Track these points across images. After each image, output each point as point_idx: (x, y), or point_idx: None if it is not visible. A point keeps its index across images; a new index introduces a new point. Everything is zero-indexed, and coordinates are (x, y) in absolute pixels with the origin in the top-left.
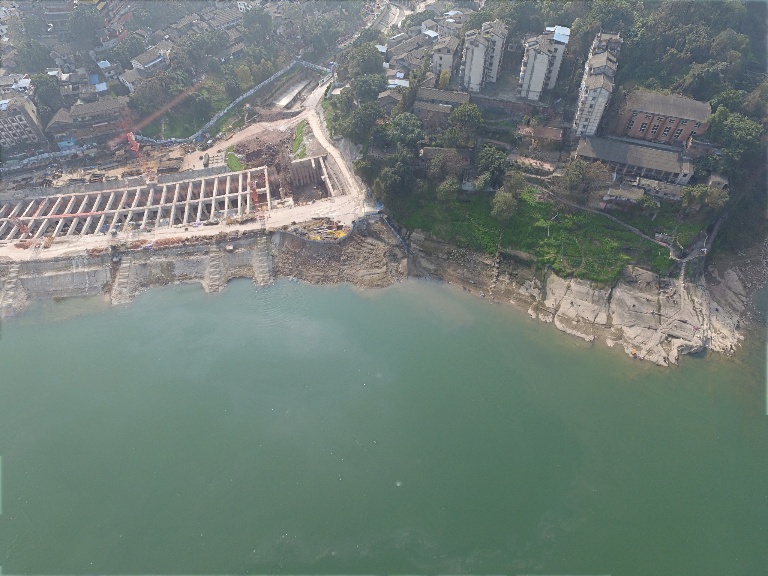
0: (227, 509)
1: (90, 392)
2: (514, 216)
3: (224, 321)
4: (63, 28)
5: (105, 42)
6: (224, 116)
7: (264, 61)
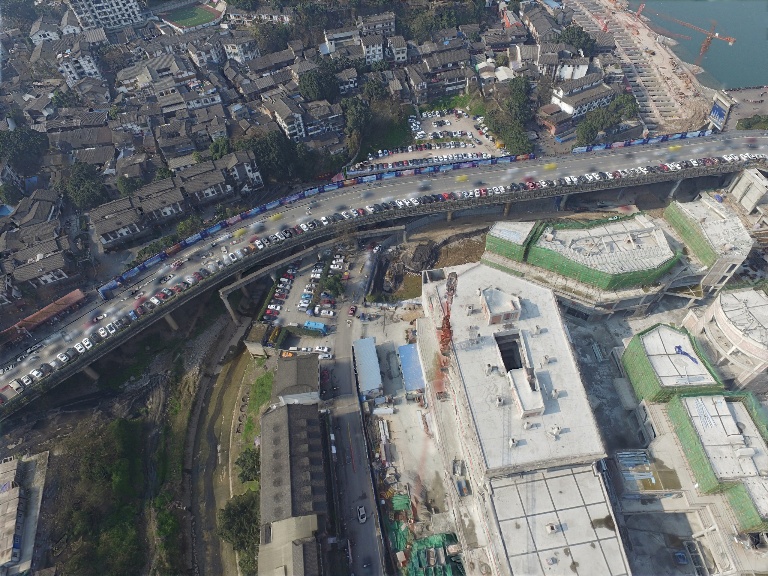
0: None
1: None
2: None
3: (642, 0)
4: None
5: None
6: None
7: None
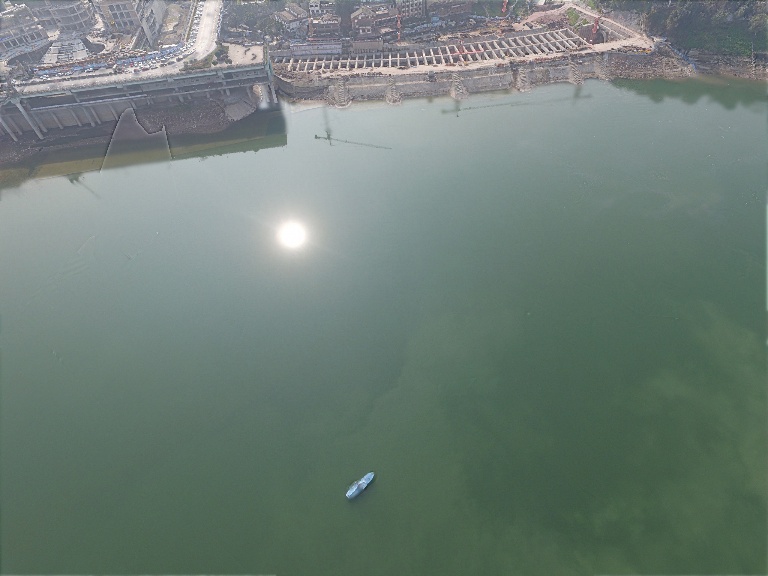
0: (668, 151)
1: (548, 120)
2: (761, 32)
3: (596, 95)
4: None
5: None
6: (515, 7)
7: None
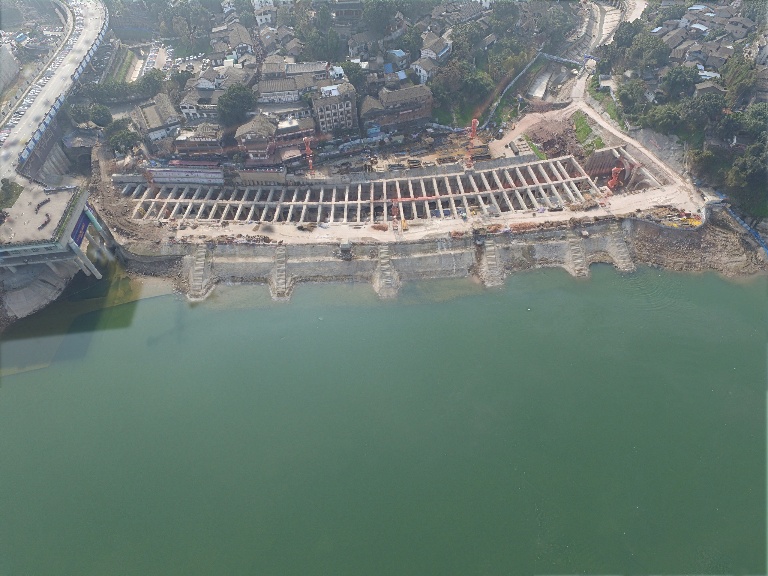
0: (729, 485)
1: (521, 370)
2: None
3: (606, 304)
4: (347, 18)
5: (395, 32)
6: (499, 106)
7: (523, 53)
